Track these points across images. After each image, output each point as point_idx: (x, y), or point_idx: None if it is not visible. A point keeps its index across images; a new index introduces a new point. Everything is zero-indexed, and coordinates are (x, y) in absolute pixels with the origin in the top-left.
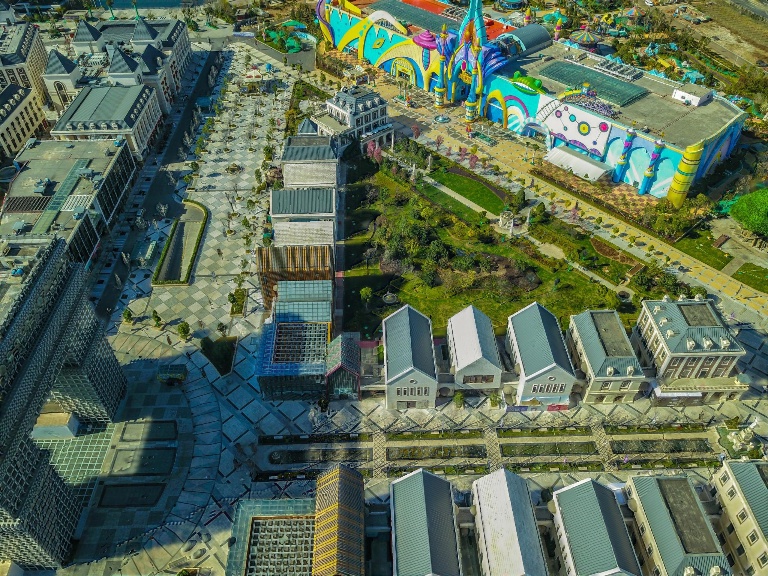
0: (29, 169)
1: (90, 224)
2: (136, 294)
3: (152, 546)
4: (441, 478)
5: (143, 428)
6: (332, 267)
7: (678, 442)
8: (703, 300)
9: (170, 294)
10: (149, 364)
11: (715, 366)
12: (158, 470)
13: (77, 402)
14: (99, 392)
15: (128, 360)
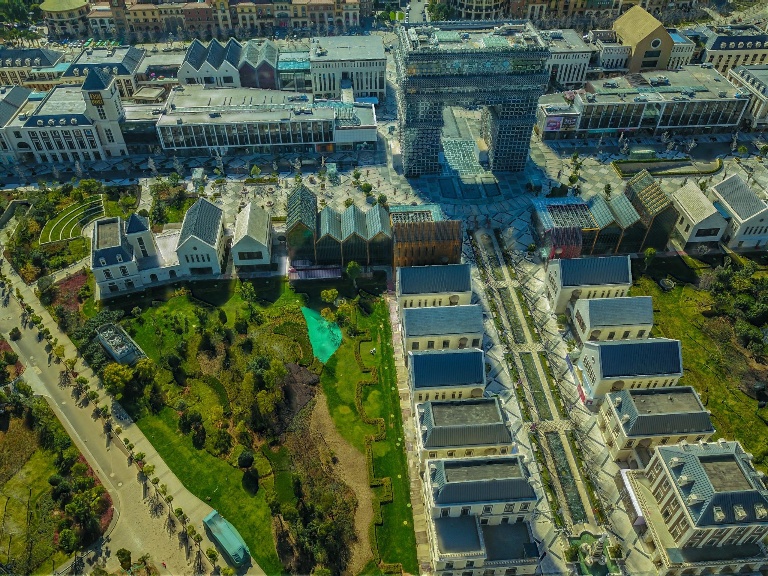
0: (676, 72)
1: (641, 112)
2: (600, 159)
3: (420, 200)
4: (471, 282)
5: (492, 183)
6: (655, 216)
7: (575, 492)
8: (764, 494)
9: (608, 172)
10: (541, 176)
11: (675, 517)
12: (465, 194)
13: (491, 144)
14: (499, 147)
15: (541, 168)
